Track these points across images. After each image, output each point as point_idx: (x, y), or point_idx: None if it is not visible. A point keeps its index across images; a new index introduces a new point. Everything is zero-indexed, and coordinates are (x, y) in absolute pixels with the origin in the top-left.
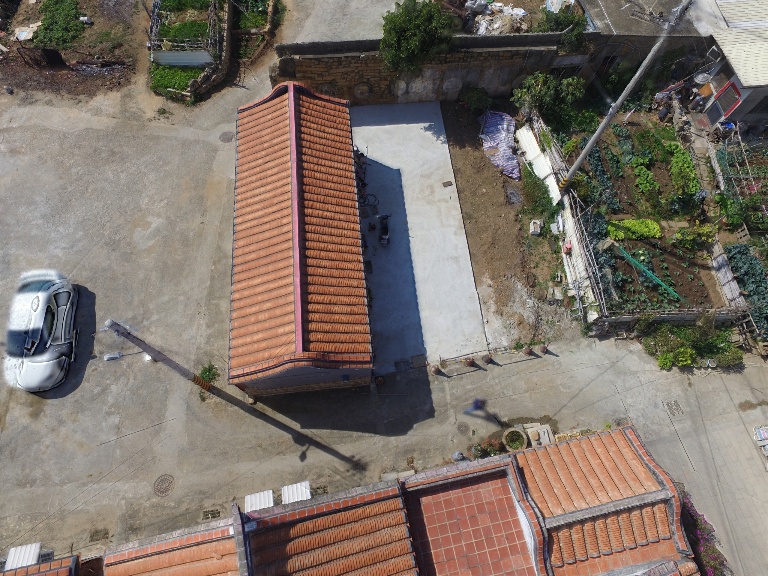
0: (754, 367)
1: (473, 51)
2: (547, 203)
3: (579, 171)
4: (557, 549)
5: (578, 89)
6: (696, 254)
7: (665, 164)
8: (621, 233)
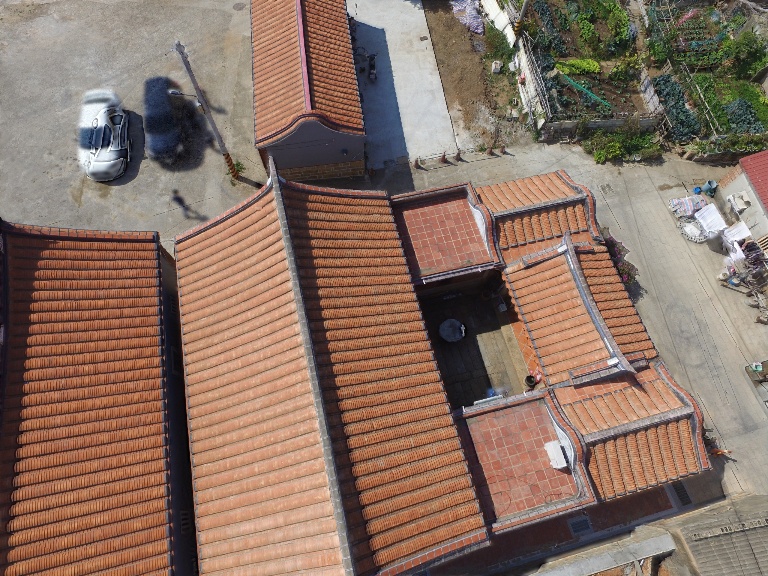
0: (672, 161)
1: None
2: (505, 47)
3: None
4: (503, 235)
5: None
6: (628, 84)
7: (605, 20)
8: (567, 69)
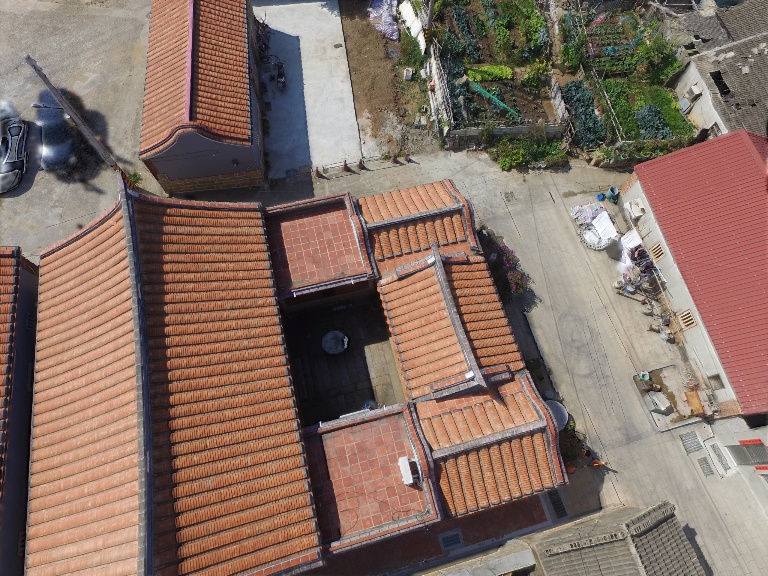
0: (579, 168)
1: None
2: (417, 54)
3: (449, 32)
4: (378, 247)
5: None
6: (541, 90)
7: None
8: (479, 76)
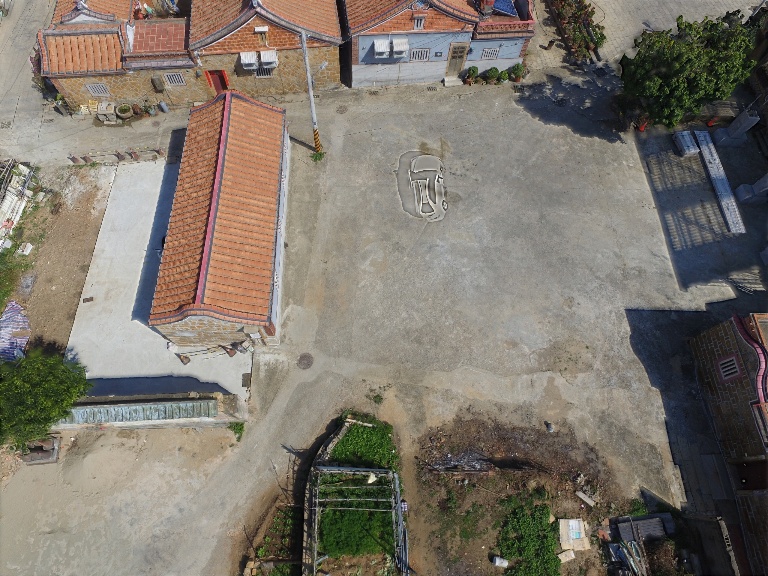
0: None
1: None
2: None
3: None
4: None
5: None
6: None
7: None
8: None
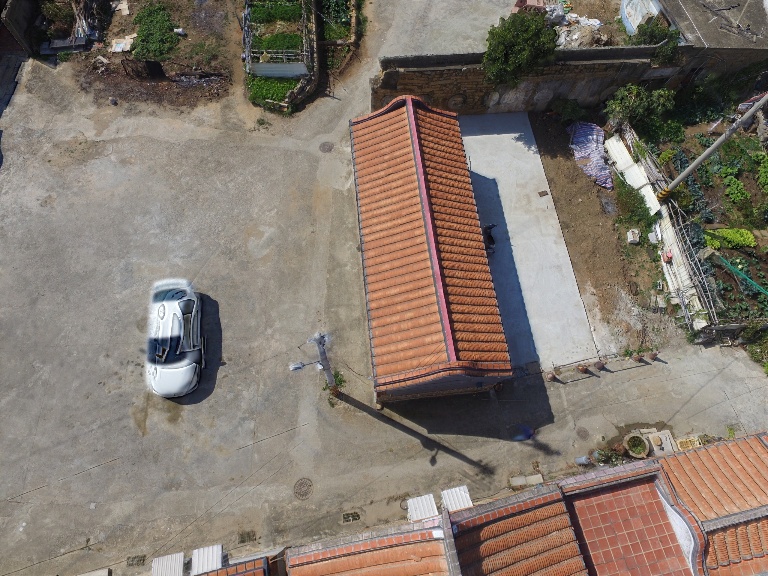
0: None
1: (570, 64)
2: (644, 213)
3: None
4: (712, 552)
5: (669, 101)
6: None
7: (752, 174)
8: (717, 242)
